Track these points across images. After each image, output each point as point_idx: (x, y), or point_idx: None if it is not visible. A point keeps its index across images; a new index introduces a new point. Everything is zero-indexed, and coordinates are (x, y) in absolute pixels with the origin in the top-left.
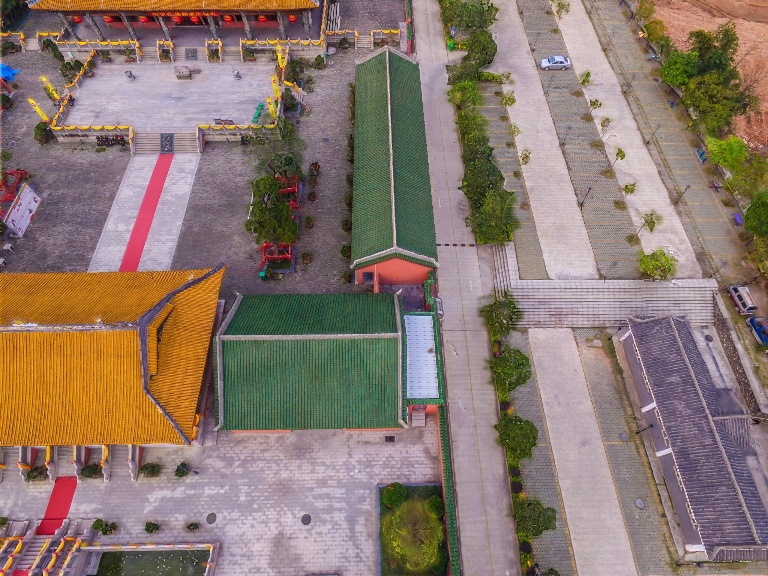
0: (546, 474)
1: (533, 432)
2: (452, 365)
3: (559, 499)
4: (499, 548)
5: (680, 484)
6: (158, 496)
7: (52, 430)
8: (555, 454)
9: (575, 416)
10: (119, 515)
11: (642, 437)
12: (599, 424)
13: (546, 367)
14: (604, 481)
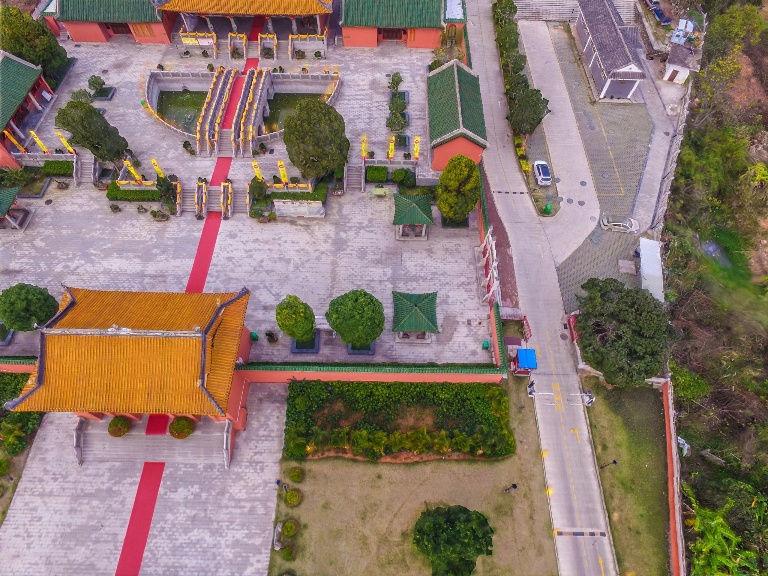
0: (524, 72)
1: (516, 26)
2: (471, 29)
3: (530, 80)
4: (495, 94)
5: (599, 66)
6: (305, 66)
7: (257, 7)
8: (530, 65)
9: (543, 53)
10: (285, 71)
11: (582, 61)
12: (557, 56)
13: (528, 35)
14: (557, 75)
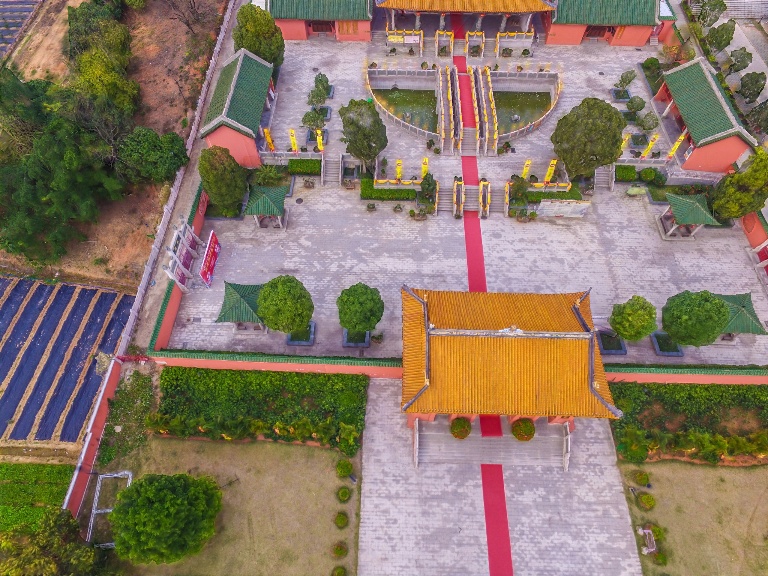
0: None
1: None
2: None
3: None
4: None
5: None
6: (514, 64)
7: (477, 4)
8: None
9: None
10: None
11: None
12: (759, 54)
13: None
14: (766, 73)
